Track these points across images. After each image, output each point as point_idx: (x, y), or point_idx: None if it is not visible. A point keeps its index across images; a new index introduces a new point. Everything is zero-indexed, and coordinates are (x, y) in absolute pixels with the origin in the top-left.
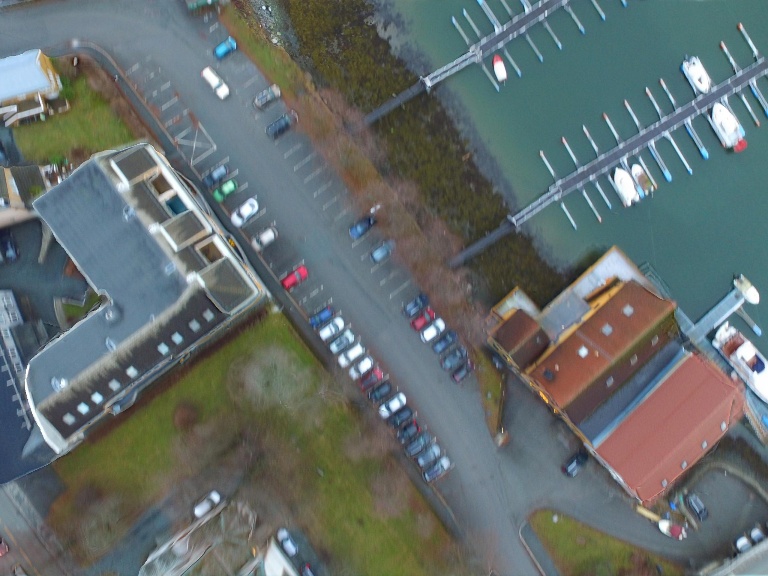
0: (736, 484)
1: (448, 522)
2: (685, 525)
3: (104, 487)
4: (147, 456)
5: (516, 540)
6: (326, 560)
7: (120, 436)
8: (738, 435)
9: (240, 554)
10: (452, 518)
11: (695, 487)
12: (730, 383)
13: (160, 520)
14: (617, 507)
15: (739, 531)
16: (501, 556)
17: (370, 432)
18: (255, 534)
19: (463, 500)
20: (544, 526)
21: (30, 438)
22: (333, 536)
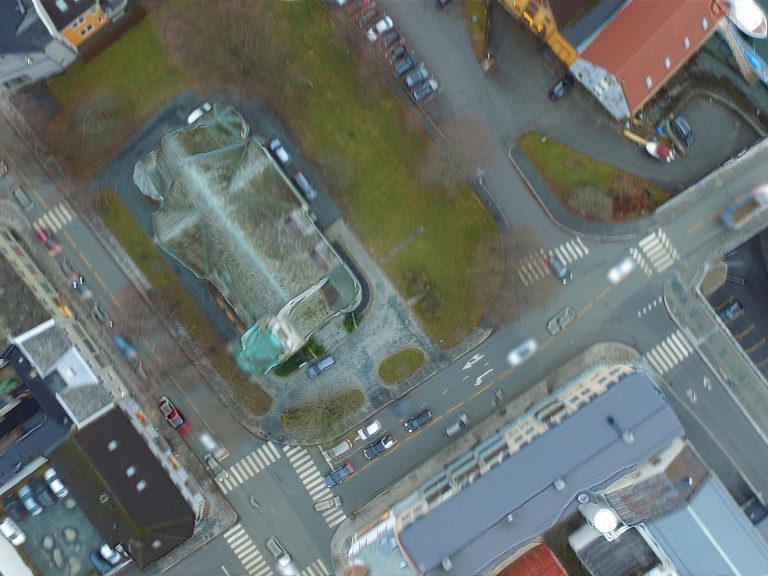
0: (721, 110)
1: (438, 138)
2: (672, 150)
3: (99, 99)
4: (140, 74)
5: (506, 160)
6: (319, 170)
7: (113, 55)
8: (722, 75)
9: (233, 141)
10: (442, 136)
11: (681, 112)
12: (712, 15)
13: (155, 135)
14: (605, 133)
15: (726, 155)
16: (491, 172)
17: (358, 51)
18: (248, 139)
19: (452, 120)
20: (533, 148)
21: (24, 21)
22: (325, 147)
